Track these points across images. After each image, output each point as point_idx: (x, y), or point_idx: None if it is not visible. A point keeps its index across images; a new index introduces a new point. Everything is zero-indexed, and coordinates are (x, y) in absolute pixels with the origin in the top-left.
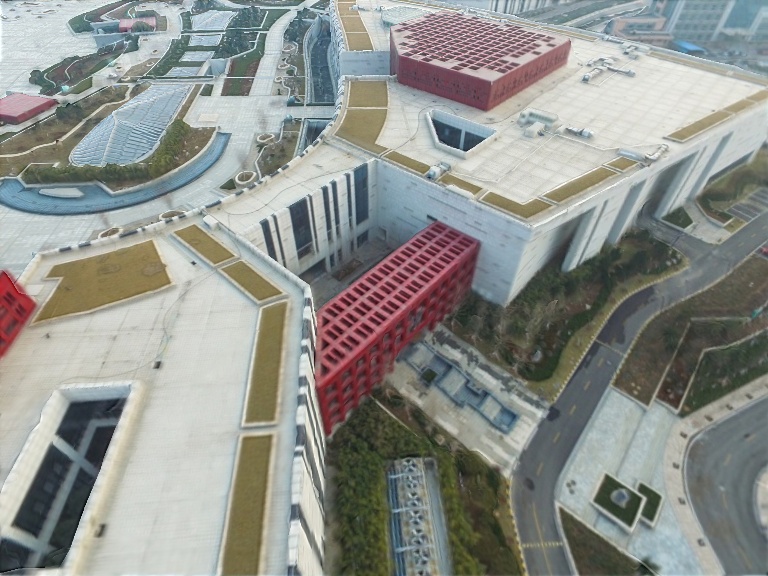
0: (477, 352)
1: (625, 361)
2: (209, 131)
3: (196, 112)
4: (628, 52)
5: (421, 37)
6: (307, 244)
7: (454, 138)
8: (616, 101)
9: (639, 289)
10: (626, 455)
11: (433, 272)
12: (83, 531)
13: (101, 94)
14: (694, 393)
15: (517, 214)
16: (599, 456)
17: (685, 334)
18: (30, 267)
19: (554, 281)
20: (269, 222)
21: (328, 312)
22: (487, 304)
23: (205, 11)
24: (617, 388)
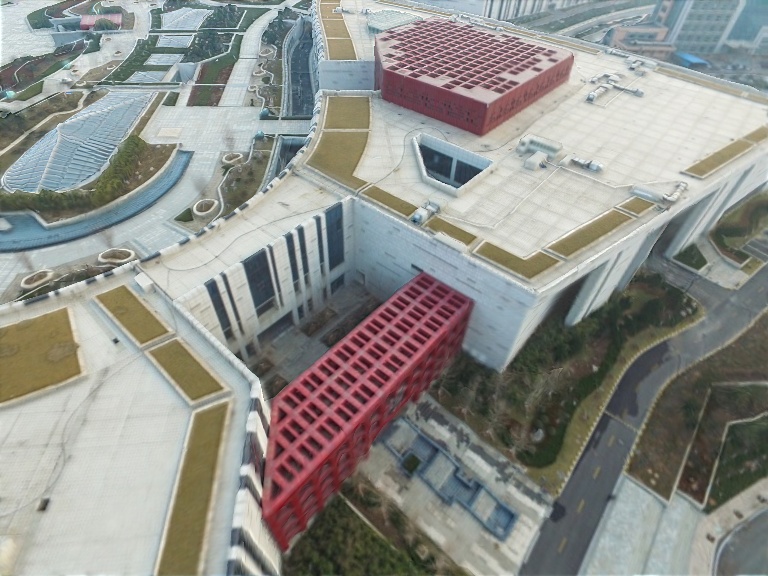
0: (468, 429)
1: (639, 440)
2: (168, 149)
3: (156, 125)
4: (634, 68)
5: (409, 47)
6: (268, 299)
7: (444, 166)
8: (625, 126)
9: (651, 345)
10: (645, 569)
11: (417, 343)
12: None
13: (50, 102)
14: (720, 482)
15: (518, 273)
16: (614, 572)
17: (706, 403)
18: None
19: (557, 338)
20: (217, 282)
21: (286, 401)
22: (480, 369)
23: (178, 8)
24: (632, 477)
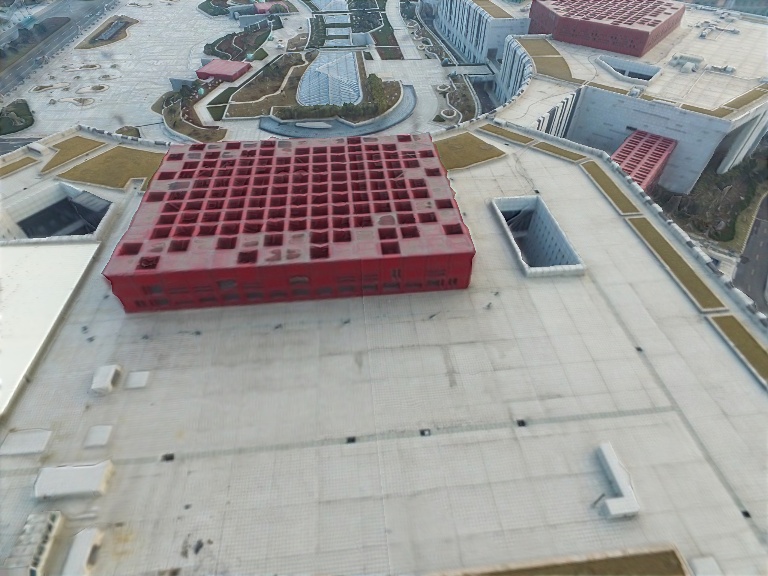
0: None
1: None
2: None
3: (372, 71)
4: (724, 17)
5: (565, 4)
6: None
7: None
8: (736, 50)
9: None
10: None
11: (656, 157)
12: None
13: (285, 59)
14: None
15: None
16: None
17: None
18: None
19: (716, 179)
20: (541, 122)
21: None
22: (673, 193)
23: None
24: None
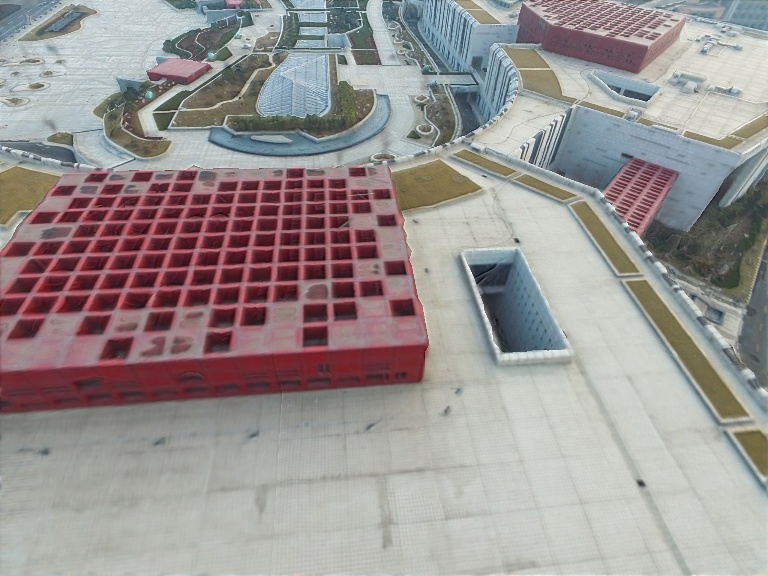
0: (672, 267)
1: None
2: (369, 92)
3: (344, 77)
4: (725, 31)
5: (557, 11)
6: None
7: None
8: (740, 68)
9: None
10: None
11: (655, 193)
12: (561, 331)
13: (250, 60)
14: None
15: (720, 146)
16: None
17: None
18: None
19: (718, 214)
20: (525, 148)
21: None
22: (671, 230)
23: None
24: None
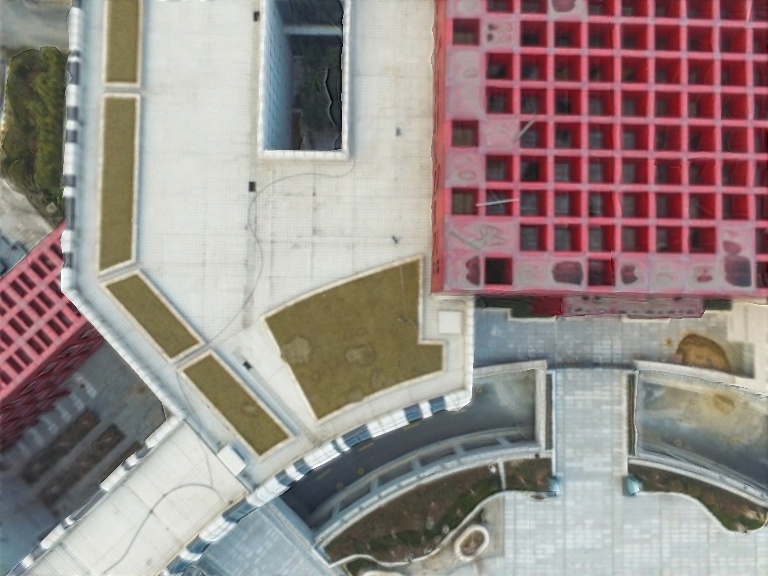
0: None
1: None
2: None
3: None
4: None
5: None
6: None
7: None
8: None
9: None
10: None
11: None
12: (262, 7)
13: None
14: None
15: None
16: None
17: None
18: (469, 362)
19: None
20: None
21: None
22: None
23: None
24: None
